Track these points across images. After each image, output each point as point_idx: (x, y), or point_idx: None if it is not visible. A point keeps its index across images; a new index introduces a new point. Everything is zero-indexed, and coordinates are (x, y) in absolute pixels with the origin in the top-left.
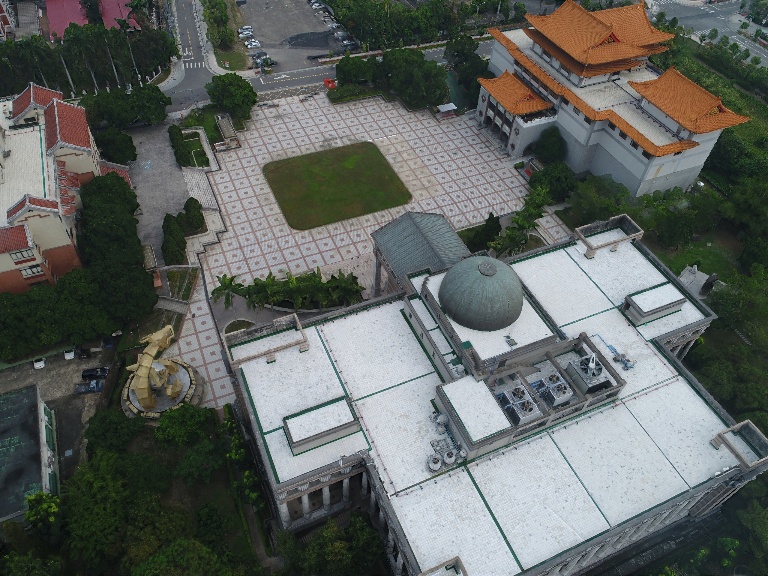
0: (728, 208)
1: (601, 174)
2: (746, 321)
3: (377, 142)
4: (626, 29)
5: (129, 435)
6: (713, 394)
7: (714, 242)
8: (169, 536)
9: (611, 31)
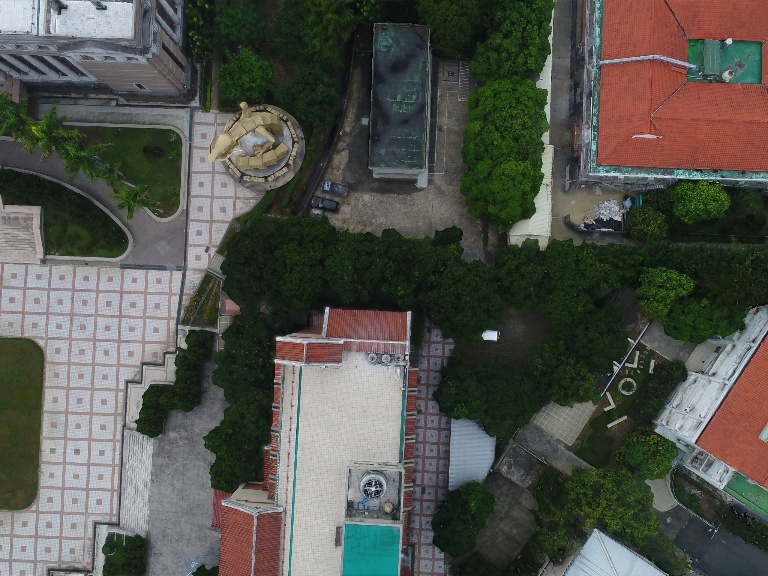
0: None
1: None
2: None
3: None
4: None
5: None
6: None
7: None
8: None
9: None
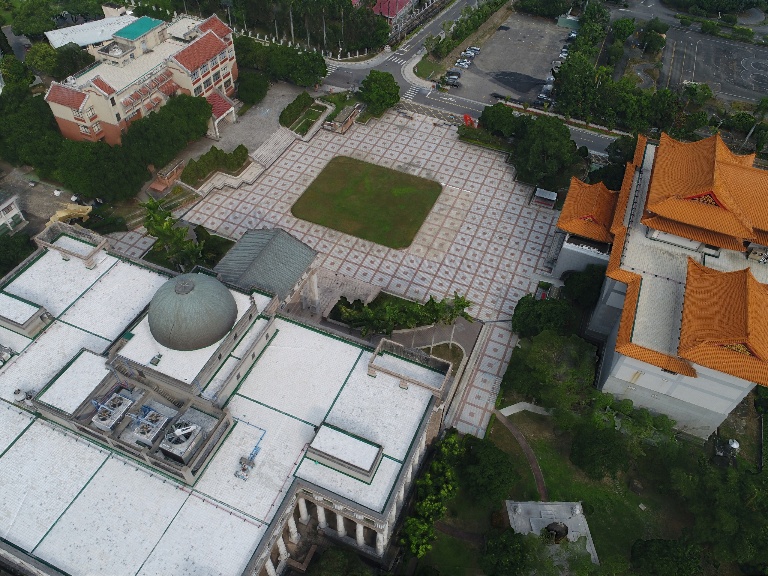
0: (685, 480)
1: (608, 346)
2: None
3: (447, 188)
4: (762, 202)
5: (14, 257)
6: None
7: (656, 511)
8: None
9: (711, 189)
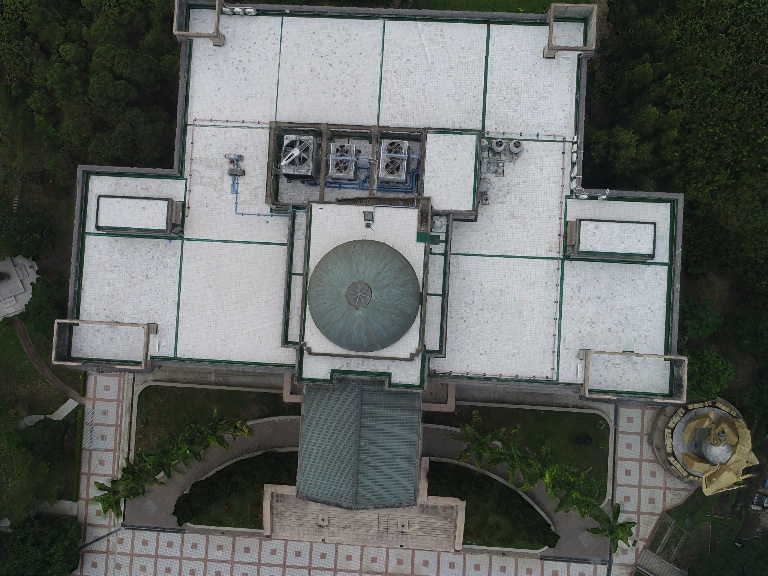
0: None
1: None
2: (5, 203)
3: None
4: None
5: (761, 384)
6: (147, 120)
7: None
8: (760, 237)
9: None
